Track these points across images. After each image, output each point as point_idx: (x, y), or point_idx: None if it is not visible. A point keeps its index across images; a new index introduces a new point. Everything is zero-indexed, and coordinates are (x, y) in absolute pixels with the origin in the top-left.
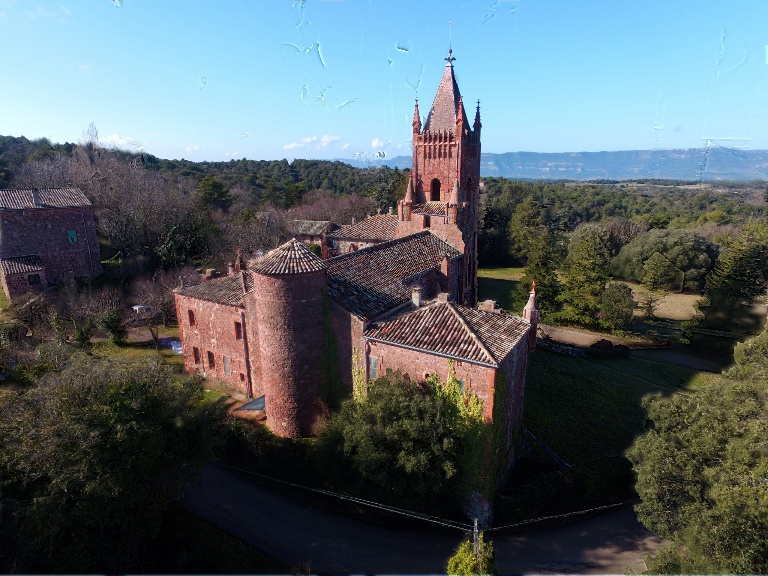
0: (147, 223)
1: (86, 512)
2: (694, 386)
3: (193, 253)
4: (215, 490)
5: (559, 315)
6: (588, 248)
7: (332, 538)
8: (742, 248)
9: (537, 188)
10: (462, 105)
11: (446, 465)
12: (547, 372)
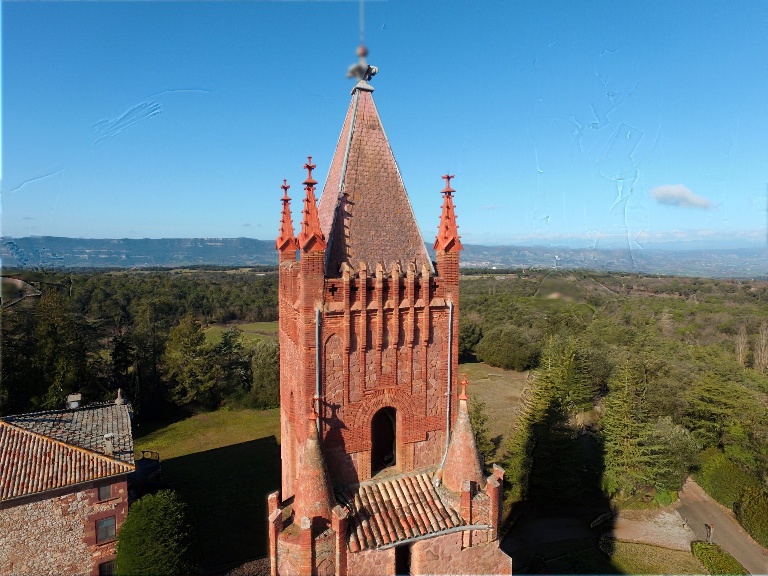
0: None
1: None
2: None
3: None
4: None
5: None
6: None
7: None
8: (549, 375)
9: (194, 302)
10: None
11: None
12: None
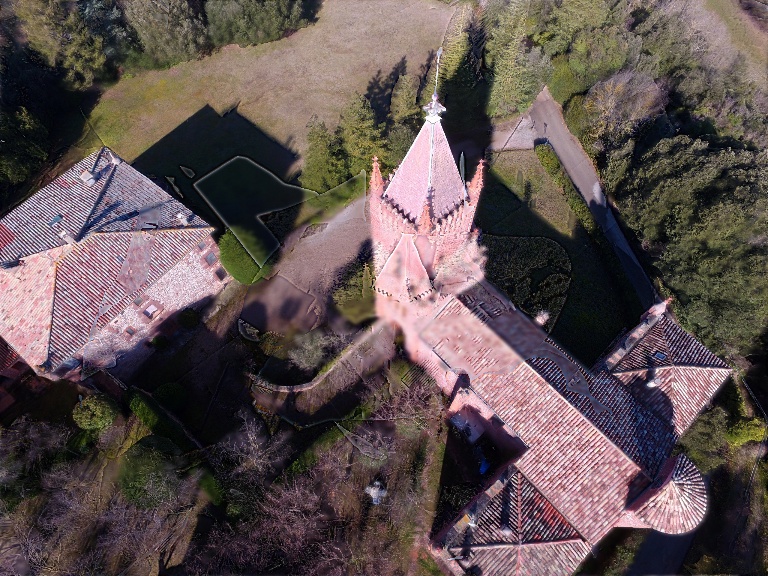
0: None
1: None
2: (513, 185)
3: None
4: (651, 569)
5: (367, 187)
6: (359, 111)
7: None
8: (459, 40)
9: None
10: None
11: None
12: None
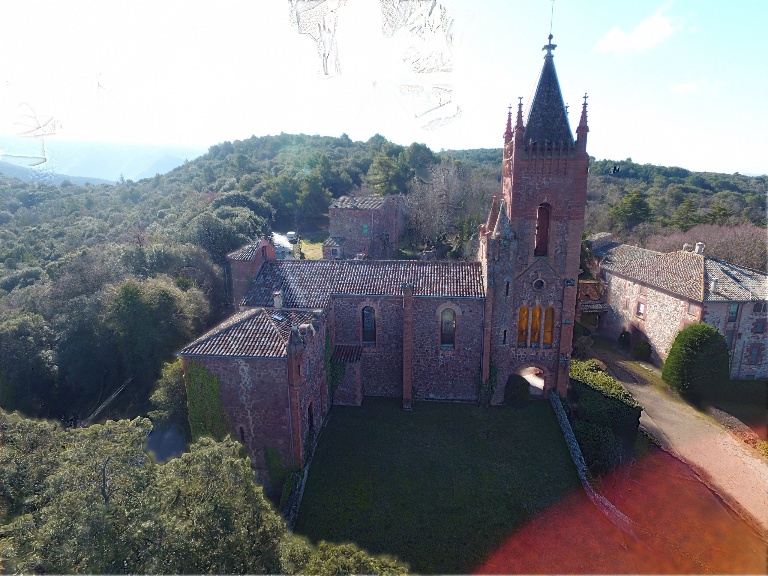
0: (419, 226)
1: (120, 339)
2: None
3: (457, 257)
4: None
5: None
6: None
7: (172, 430)
8: None
9: None
10: (560, 105)
11: (160, 411)
12: (498, 492)
